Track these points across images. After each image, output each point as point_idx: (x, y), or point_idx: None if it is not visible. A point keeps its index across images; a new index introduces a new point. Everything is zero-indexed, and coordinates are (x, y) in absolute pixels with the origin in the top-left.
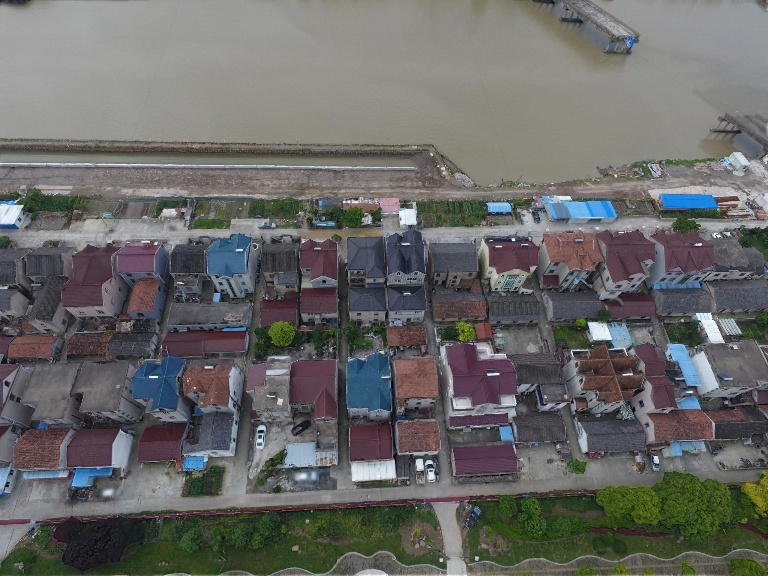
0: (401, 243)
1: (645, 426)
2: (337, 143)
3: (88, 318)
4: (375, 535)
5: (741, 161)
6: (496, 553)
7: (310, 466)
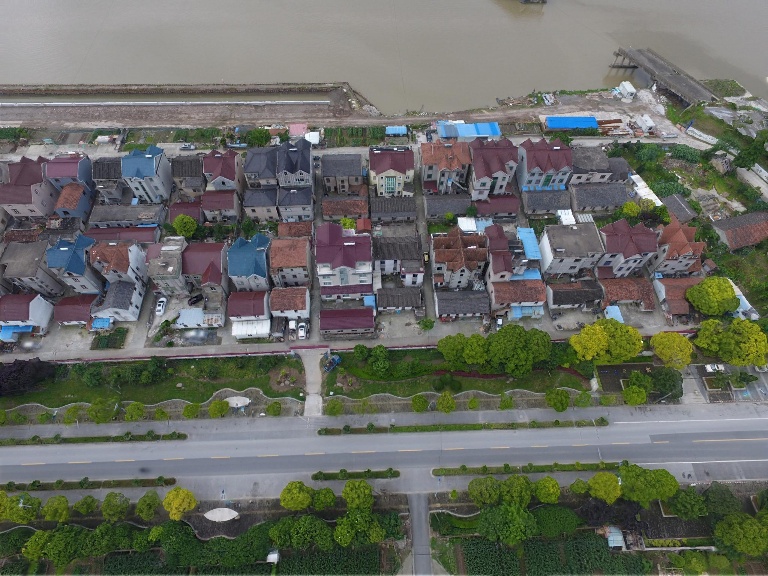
0: None
1: (491, 294)
2: (261, 83)
3: (24, 219)
4: (248, 376)
5: (628, 89)
6: (349, 390)
7: (200, 327)
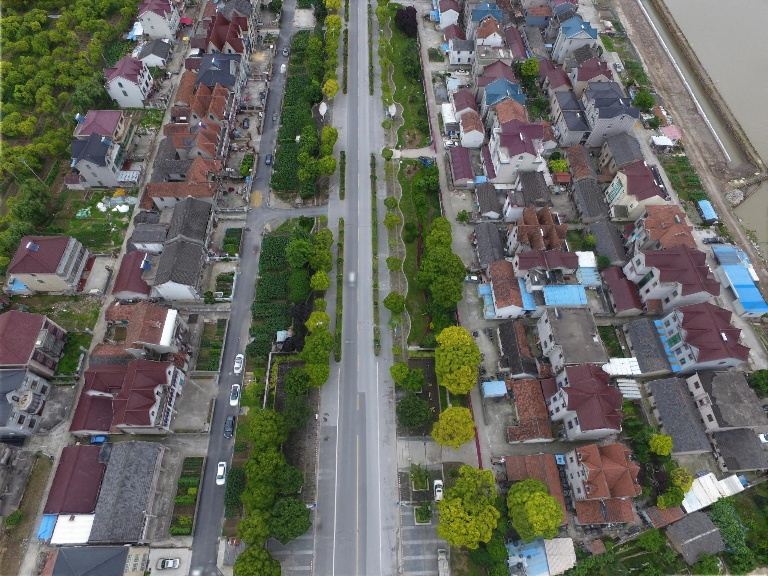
0: None
1: None
2: (732, 110)
3: (520, 4)
4: (413, 118)
5: None
6: (404, 172)
7: None
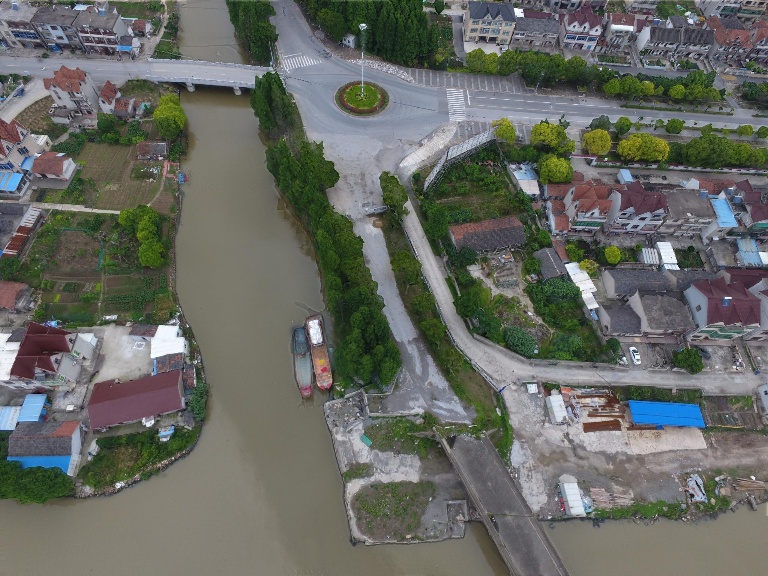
0: None
1: None
2: None
3: None
4: None
5: (577, 492)
6: None
7: None
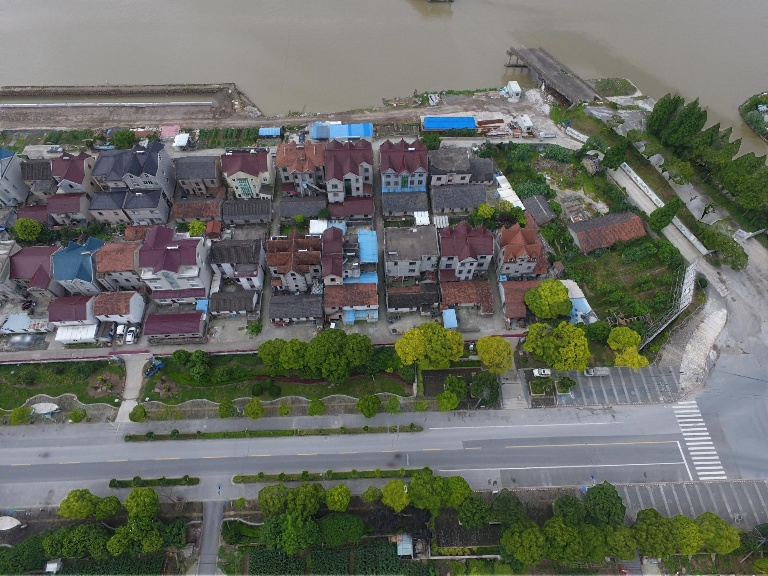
0: (137, 151)
1: None
2: (147, 84)
3: None
4: (65, 382)
5: (513, 88)
6: (166, 395)
7: (28, 332)
